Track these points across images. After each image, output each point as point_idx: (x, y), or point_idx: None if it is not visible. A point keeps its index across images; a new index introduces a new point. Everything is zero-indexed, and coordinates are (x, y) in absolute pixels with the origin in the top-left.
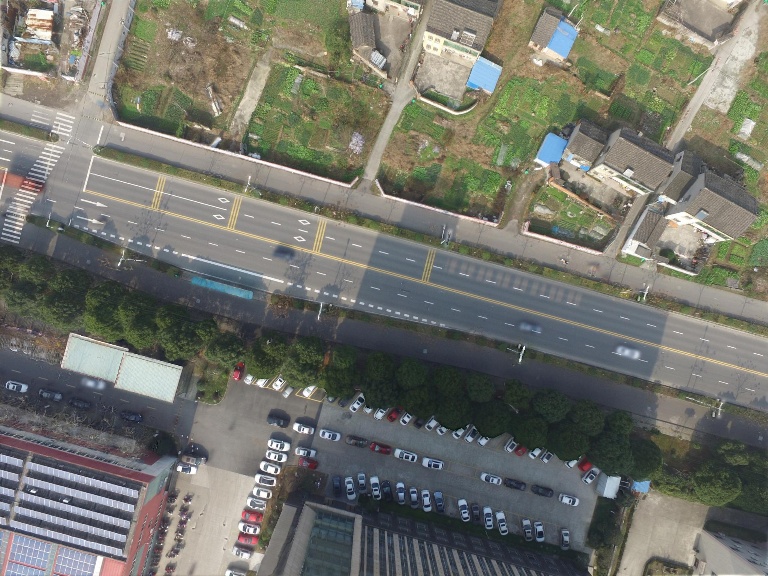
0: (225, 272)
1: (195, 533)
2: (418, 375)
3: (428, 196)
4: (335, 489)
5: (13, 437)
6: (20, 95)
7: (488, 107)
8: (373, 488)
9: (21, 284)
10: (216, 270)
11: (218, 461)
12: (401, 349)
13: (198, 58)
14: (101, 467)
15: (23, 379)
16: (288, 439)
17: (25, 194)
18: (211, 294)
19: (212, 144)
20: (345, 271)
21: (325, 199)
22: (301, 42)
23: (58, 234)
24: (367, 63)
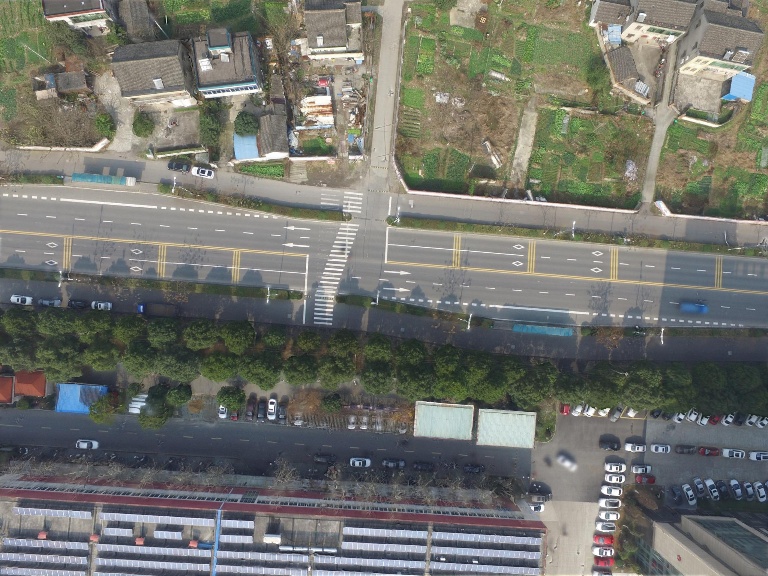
0: (533, 315)
1: (553, 566)
2: (759, 377)
3: (706, 208)
4: (678, 498)
5: (398, 511)
6: (305, 181)
7: (744, 115)
8: (712, 490)
9: (375, 364)
10: (524, 314)
11: (561, 494)
12: (710, 355)
13: (468, 116)
14: (497, 523)
15: (363, 454)
16: (622, 460)
17: (329, 276)
18: (524, 338)
19: (504, 196)
20: (644, 292)
21: (612, 228)
22: (561, 84)
23: (369, 308)
24: (627, 93)
